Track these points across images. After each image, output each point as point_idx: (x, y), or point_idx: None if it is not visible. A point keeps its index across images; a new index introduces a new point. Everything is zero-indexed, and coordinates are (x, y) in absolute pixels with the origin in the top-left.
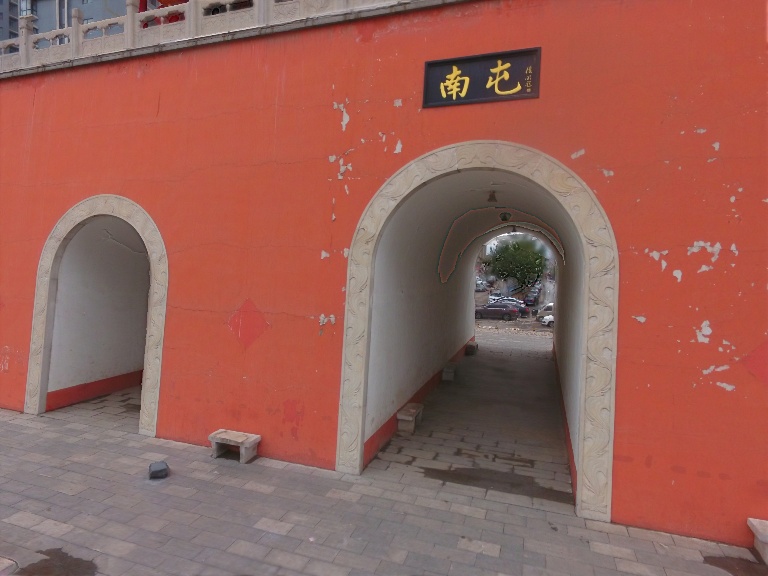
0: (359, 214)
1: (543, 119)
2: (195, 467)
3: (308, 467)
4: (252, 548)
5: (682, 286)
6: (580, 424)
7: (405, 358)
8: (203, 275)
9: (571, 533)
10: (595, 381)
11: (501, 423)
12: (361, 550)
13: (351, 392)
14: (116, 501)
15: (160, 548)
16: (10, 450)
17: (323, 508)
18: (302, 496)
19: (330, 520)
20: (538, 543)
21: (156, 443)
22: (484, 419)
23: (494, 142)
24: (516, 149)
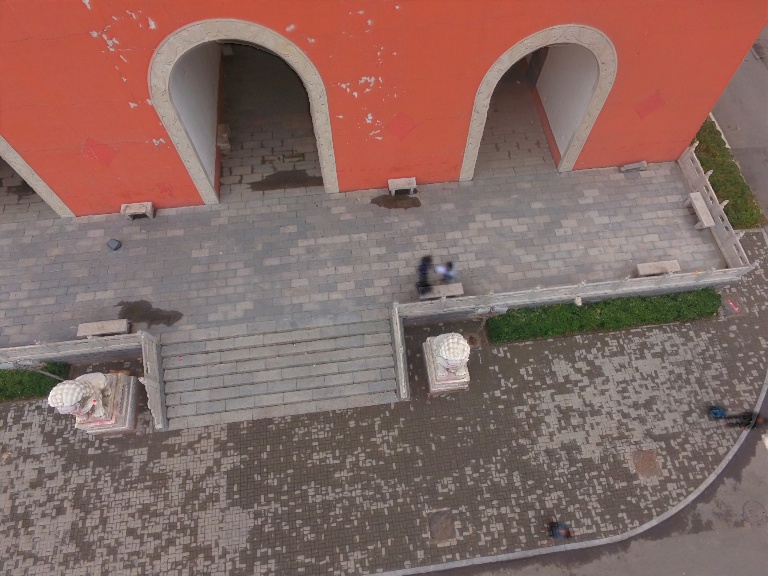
0: (145, 76)
1: (259, 1)
2: (129, 232)
3: (189, 207)
4: (200, 268)
5: (358, 100)
6: (320, 163)
7: (205, 104)
8: (33, 128)
9: (323, 206)
10: (324, 146)
11: (281, 115)
12: (244, 250)
13: (196, 173)
14: (115, 270)
15: (163, 283)
16: (2, 264)
17: (215, 234)
18: (200, 230)
19: (222, 240)
20: (311, 217)
21: (83, 222)
22: (269, 114)
23: (229, 20)
24: (247, 25)
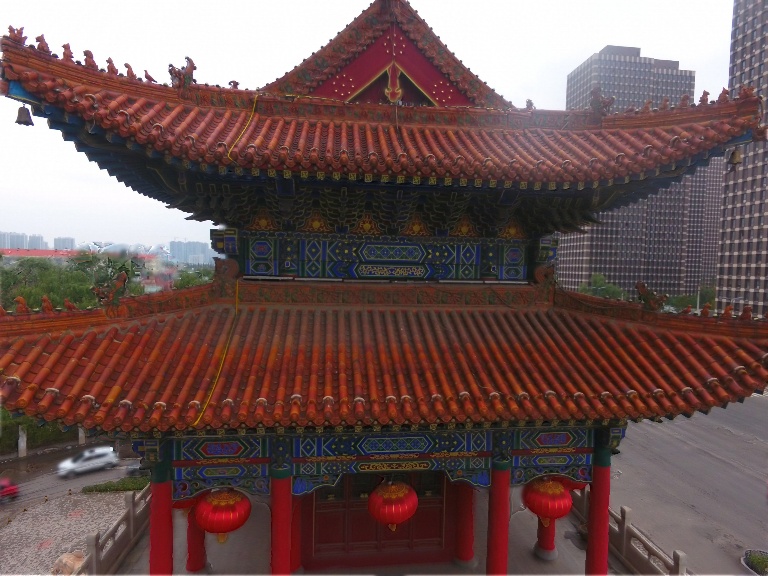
0: None
1: None
2: None
3: None
4: None
5: None
6: None
7: None
8: None
9: None
10: None
11: None
12: None
13: None
14: None
15: None
16: None
17: None
18: None
19: None
20: None
21: None
22: None
23: None
24: None
